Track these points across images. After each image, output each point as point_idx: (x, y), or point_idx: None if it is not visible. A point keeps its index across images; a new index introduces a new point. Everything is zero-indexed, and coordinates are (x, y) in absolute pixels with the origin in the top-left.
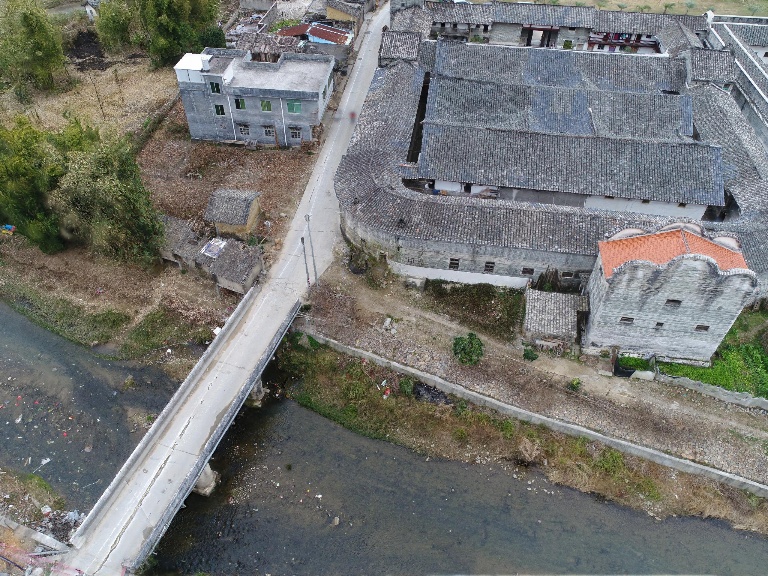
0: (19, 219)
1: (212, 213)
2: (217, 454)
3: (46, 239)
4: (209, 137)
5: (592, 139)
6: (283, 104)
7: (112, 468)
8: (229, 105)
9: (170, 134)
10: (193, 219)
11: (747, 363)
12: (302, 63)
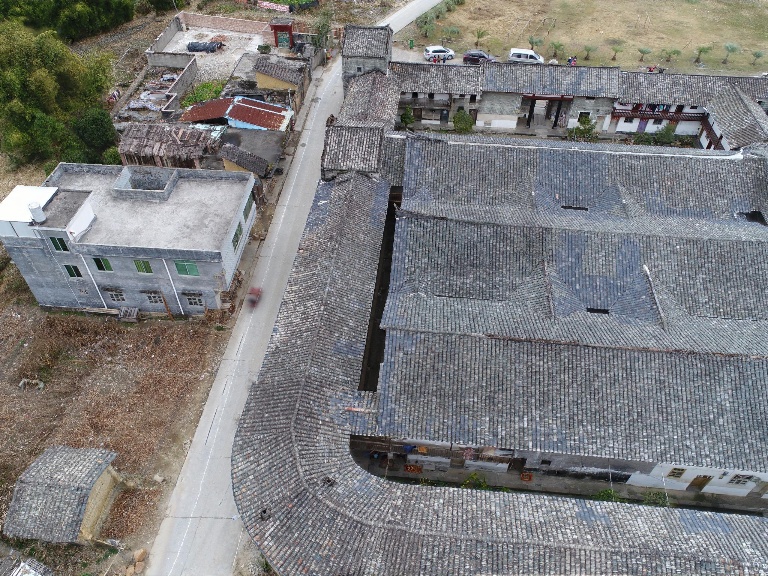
0: None
1: (17, 519)
2: None
3: None
4: (66, 304)
5: (667, 354)
6: (169, 265)
7: None
8: (86, 266)
9: (10, 295)
10: (3, 500)
11: None
12: (205, 184)
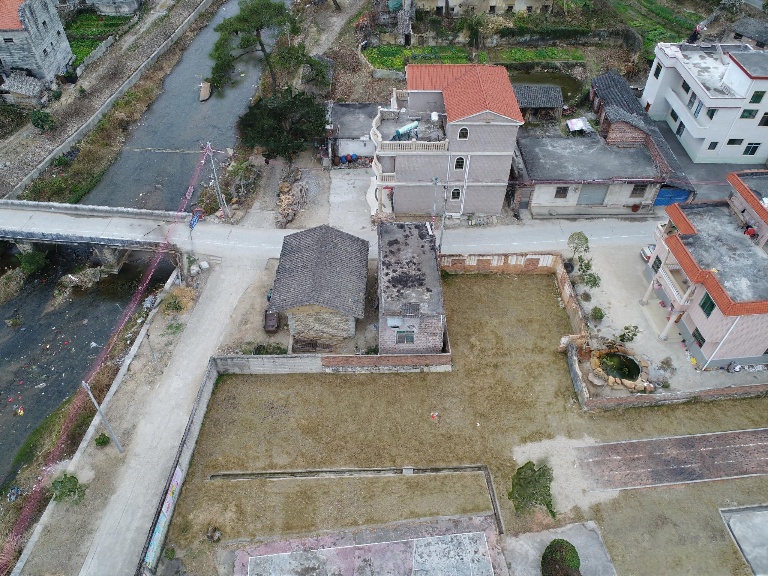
0: None
1: None
2: None
3: None
4: None
5: None
6: None
7: (106, 300)
8: None
9: None
10: None
11: (76, 47)
12: None
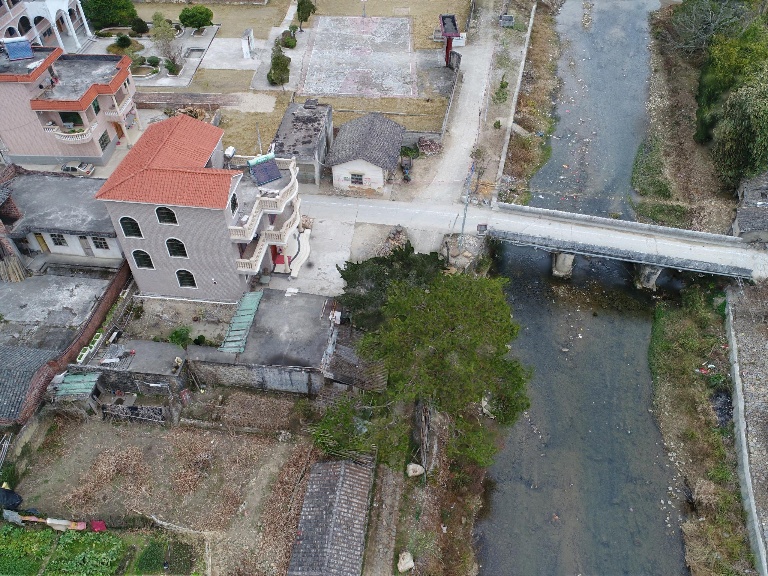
0: (703, 101)
1: None
2: (585, 273)
3: (701, 126)
4: None
5: None
6: None
7: None
8: None
9: None
10: None
11: None
12: None
